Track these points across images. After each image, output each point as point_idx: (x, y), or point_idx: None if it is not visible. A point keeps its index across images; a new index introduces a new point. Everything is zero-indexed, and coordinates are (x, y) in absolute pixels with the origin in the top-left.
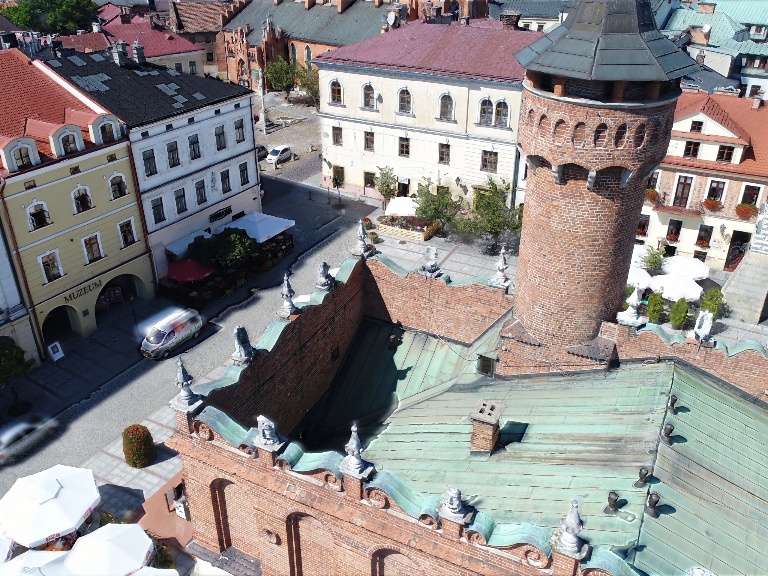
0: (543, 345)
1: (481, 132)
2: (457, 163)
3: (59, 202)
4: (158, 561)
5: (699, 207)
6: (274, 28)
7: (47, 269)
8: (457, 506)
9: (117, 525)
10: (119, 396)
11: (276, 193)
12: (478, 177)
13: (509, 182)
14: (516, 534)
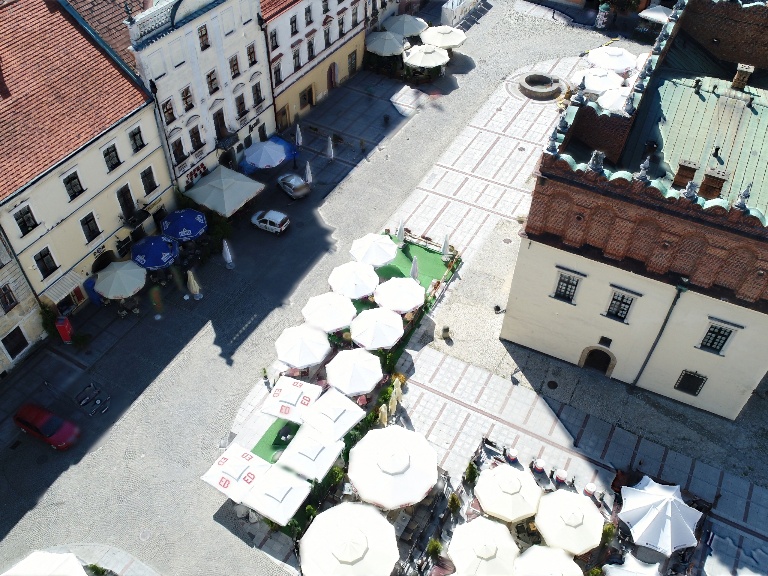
0: None
1: None
2: None
3: None
4: None
5: None
6: None
7: None
8: None
9: None
10: None
11: None
12: None
13: None
14: None
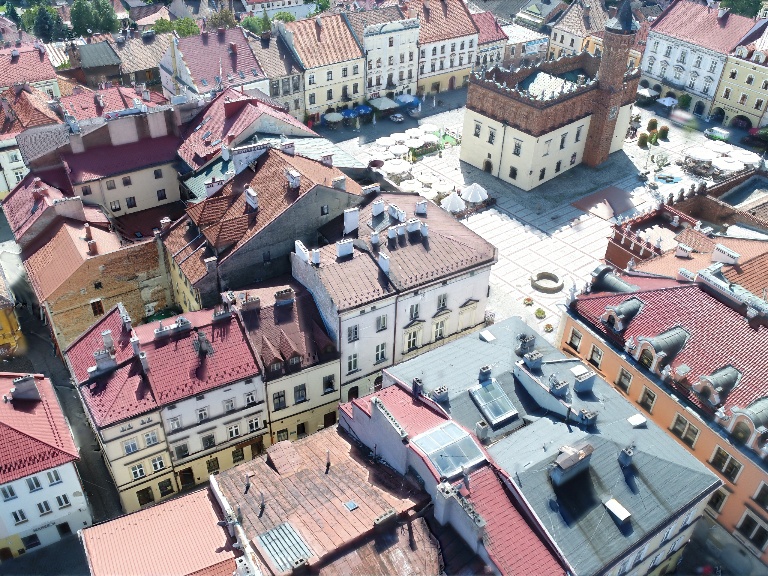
0: None
1: None
2: None
3: None
4: None
5: None
6: None
7: None
8: None
9: None
10: (684, 129)
11: None
12: None
13: None
14: None
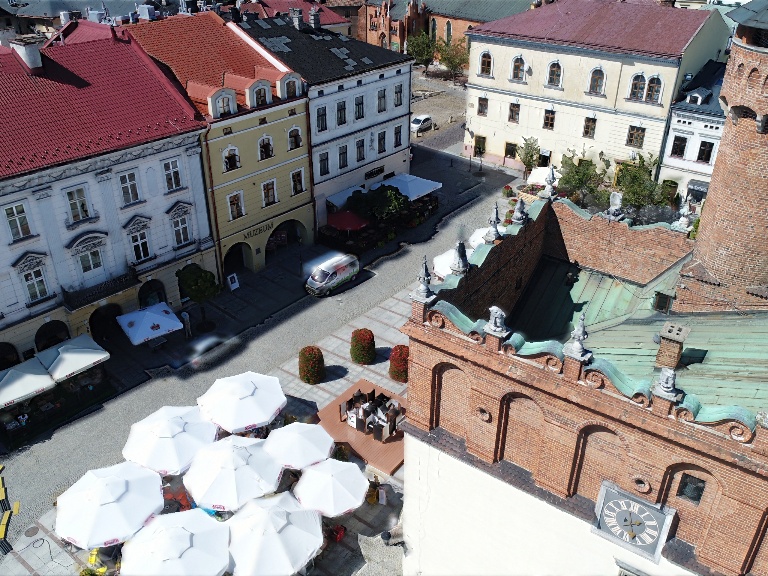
0: (723, 285)
1: (630, 107)
2: (602, 137)
3: (248, 149)
4: (337, 458)
5: None
6: (417, 3)
7: (233, 208)
8: (671, 385)
9: (303, 424)
10: (289, 324)
11: (419, 159)
12: (622, 152)
13: (655, 158)
14: (722, 413)
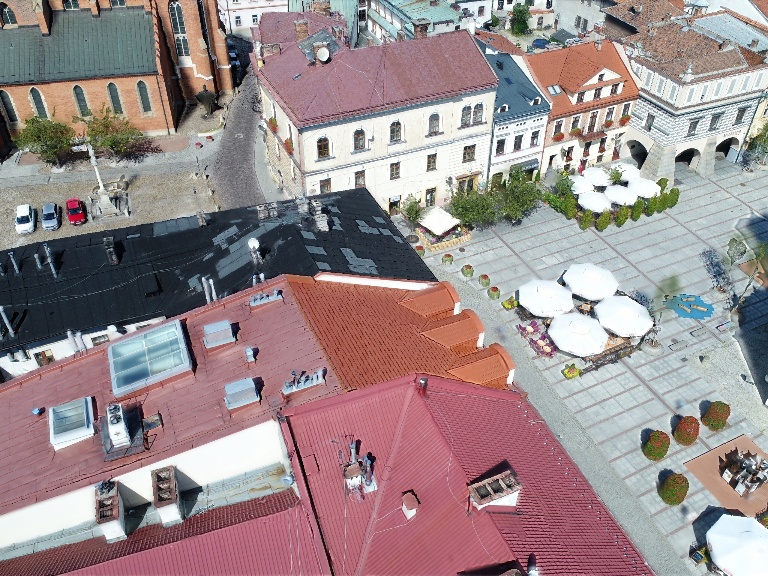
0: None
1: (463, 133)
2: (444, 165)
3: None
4: None
5: (601, 128)
6: None
7: None
8: None
9: None
10: None
11: None
12: (461, 169)
13: None
14: None
